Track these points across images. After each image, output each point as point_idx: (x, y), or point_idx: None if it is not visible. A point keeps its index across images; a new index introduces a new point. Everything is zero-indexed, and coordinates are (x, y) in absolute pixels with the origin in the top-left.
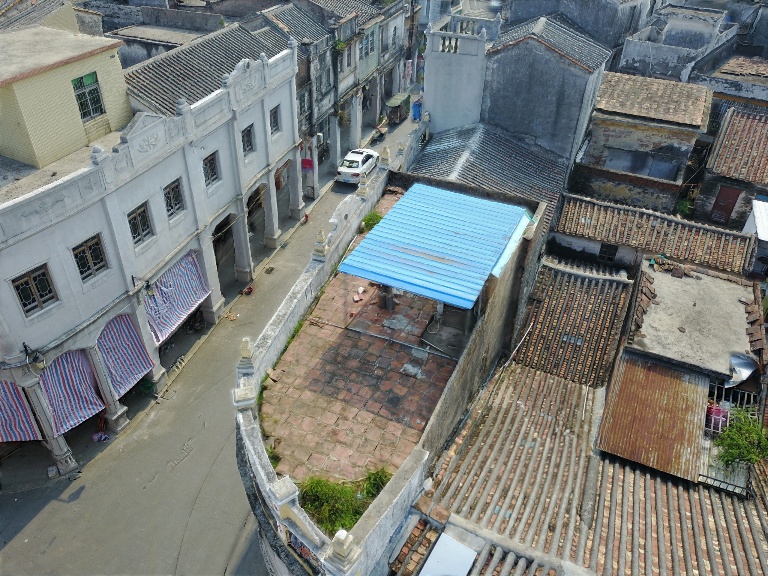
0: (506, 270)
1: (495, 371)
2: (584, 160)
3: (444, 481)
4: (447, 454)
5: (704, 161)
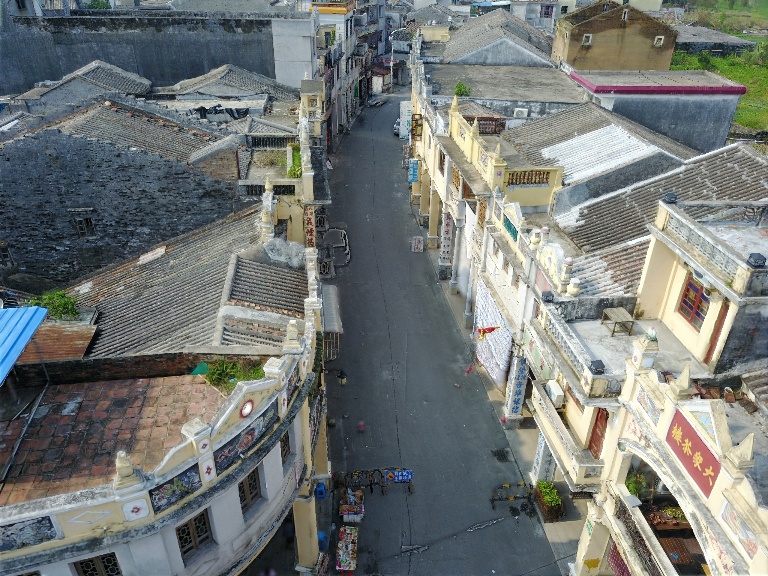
0: None
1: None
2: None
3: None
4: None
5: None
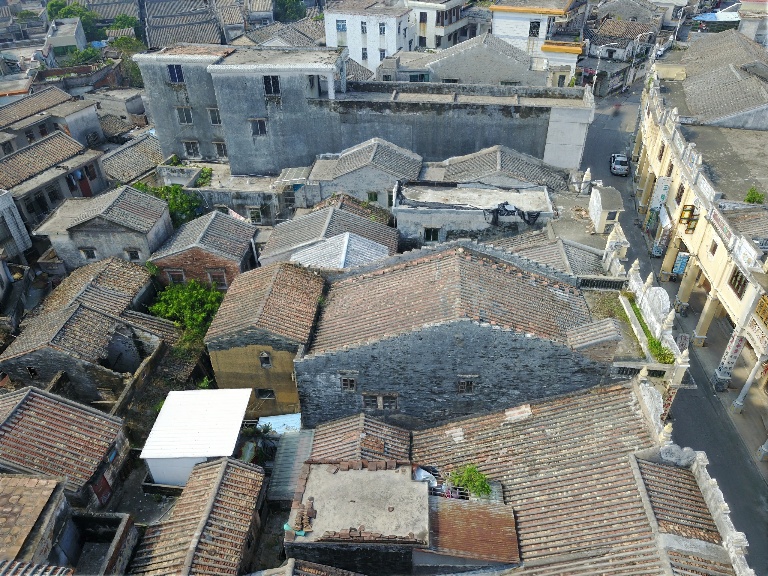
0: None
1: None
2: None
3: None
4: None
5: None
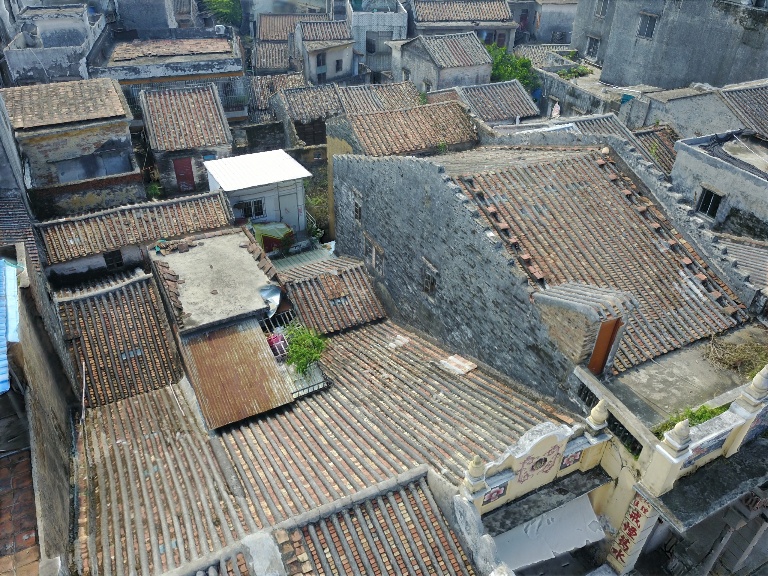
0: (22, 329)
1: (76, 430)
2: (35, 184)
3: (94, 569)
4: (79, 542)
5: (147, 144)
